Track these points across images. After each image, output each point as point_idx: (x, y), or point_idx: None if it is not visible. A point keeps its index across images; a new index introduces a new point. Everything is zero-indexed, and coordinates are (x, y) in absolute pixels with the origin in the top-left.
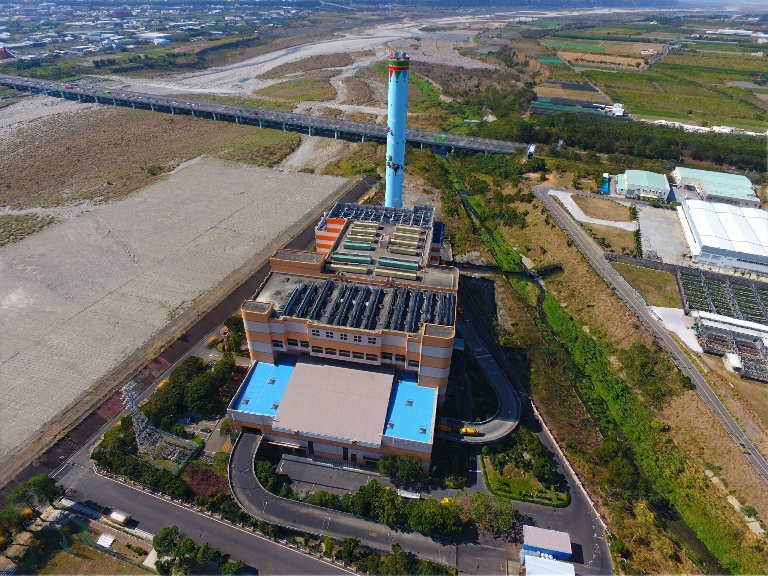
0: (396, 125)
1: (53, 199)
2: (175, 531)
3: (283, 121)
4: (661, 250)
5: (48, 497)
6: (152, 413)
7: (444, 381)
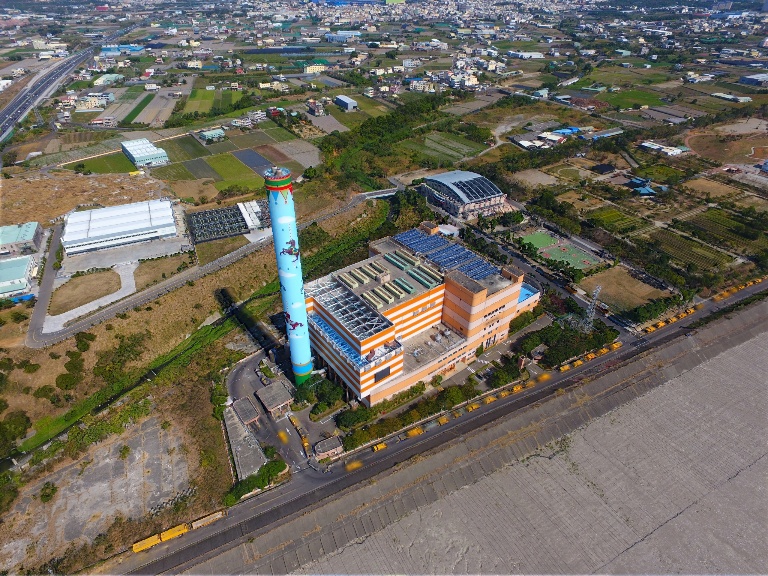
0: None
1: None
2: None
3: None
4: (168, 248)
5: None
6: (584, 334)
7: None
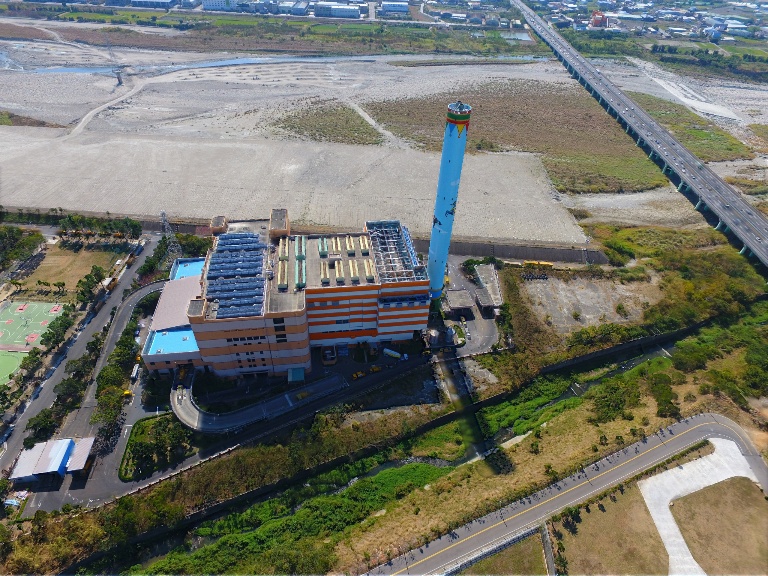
0: (440, 177)
1: (406, 132)
2: (100, 271)
3: (667, 161)
4: None
5: (133, 232)
6: (192, 242)
7: (200, 350)
